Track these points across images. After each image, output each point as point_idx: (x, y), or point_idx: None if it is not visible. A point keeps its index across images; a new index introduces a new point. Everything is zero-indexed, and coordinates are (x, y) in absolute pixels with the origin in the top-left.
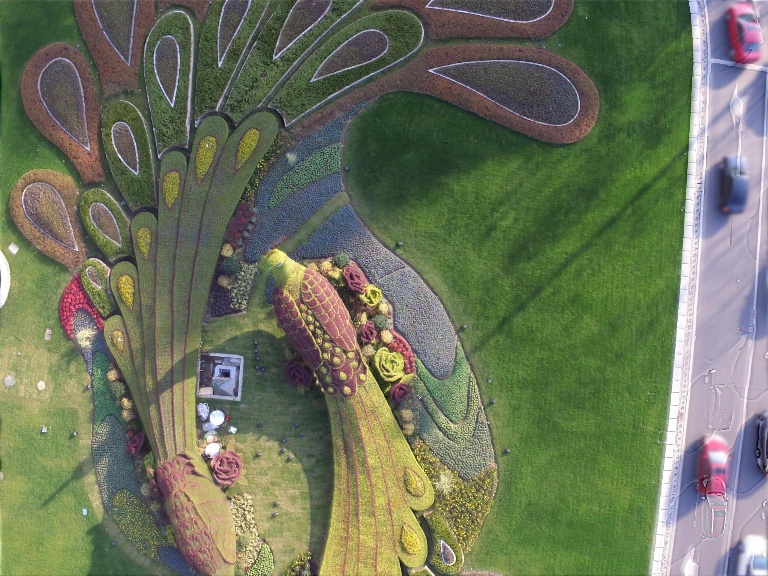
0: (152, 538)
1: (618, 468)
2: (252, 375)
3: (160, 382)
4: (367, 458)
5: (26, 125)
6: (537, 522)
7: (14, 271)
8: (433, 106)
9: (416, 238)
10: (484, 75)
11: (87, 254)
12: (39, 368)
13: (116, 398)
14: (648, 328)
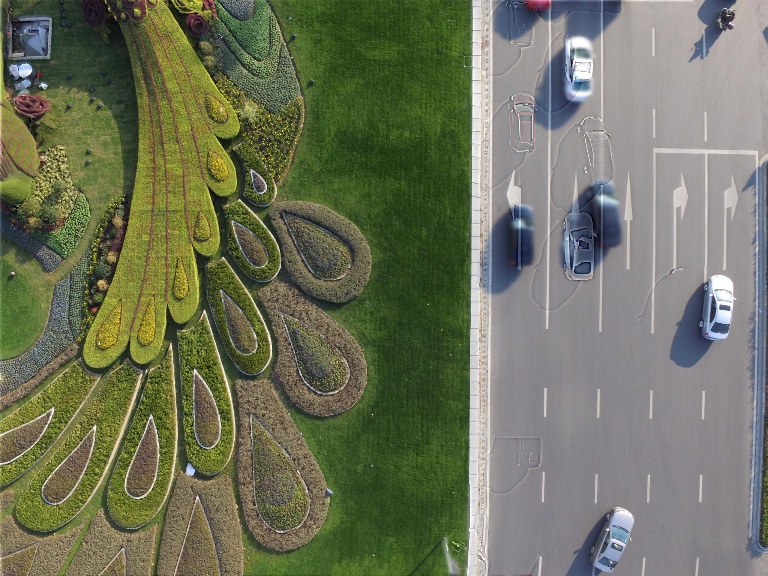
0: None
1: (425, 92)
2: (60, 33)
3: None
4: (165, 83)
5: None
6: (348, 149)
7: None
8: None
9: None
10: None
11: None
12: None
13: None
14: None
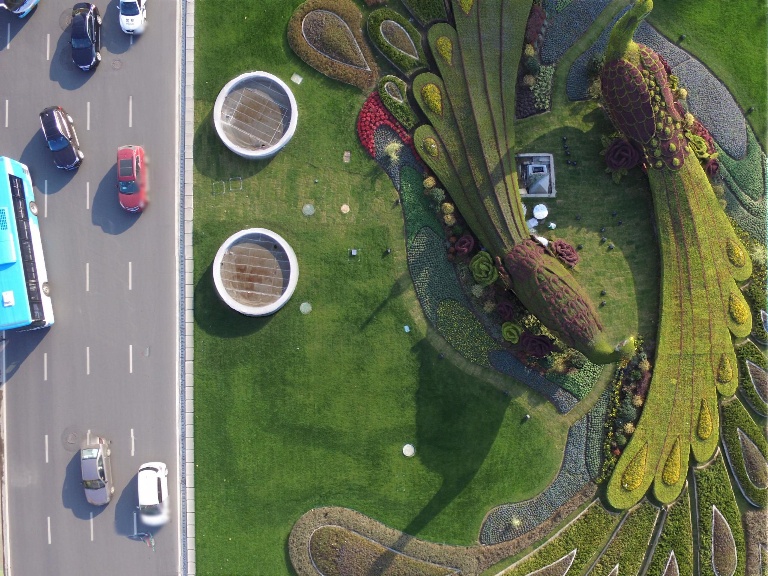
0: (483, 343)
1: None
2: (564, 170)
3: (492, 174)
4: (696, 230)
5: None
6: None
7: (300, 100)
8: None
9: (696, 31)
10: None
11: (379, 73)
12: (341, 192)
13: (436, 204)
14: None
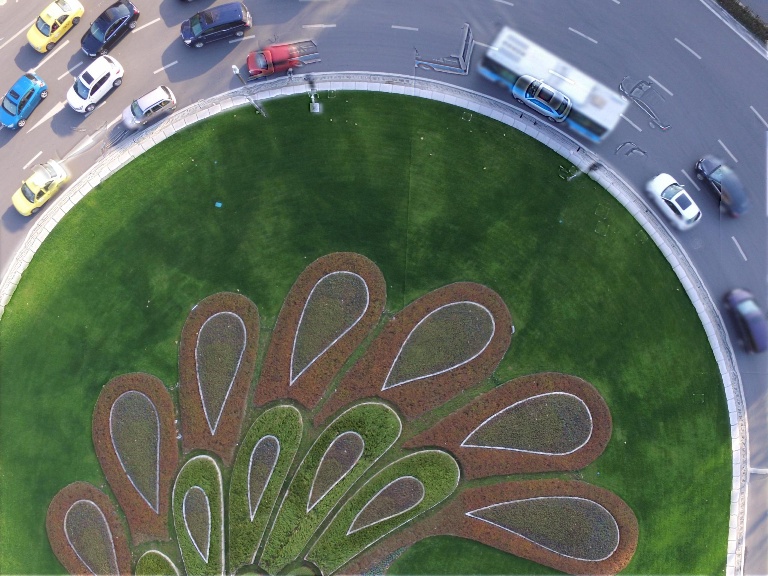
0: None
1: None
2: None
3: None
4: None
5: (56, 565)
6: None
7: None
8: (472, 548)
9: None
10: (523, 518)
11: None
12: None
13: None
14: None
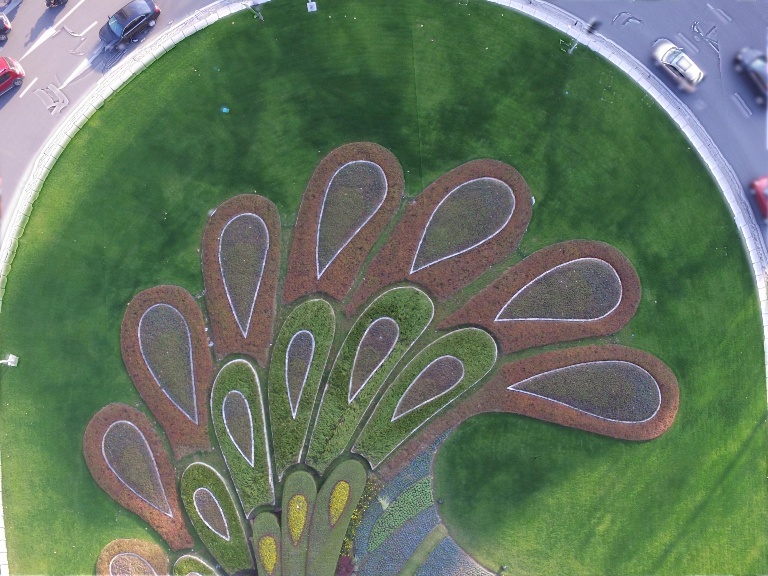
0: None
1: None
2: None
3: None
4: None
5: (97, 493)
6: None
7: None
8: (517, 423)
9: (519, 558)
10: (564, 385)
11: None
12: None
13: None
14: None
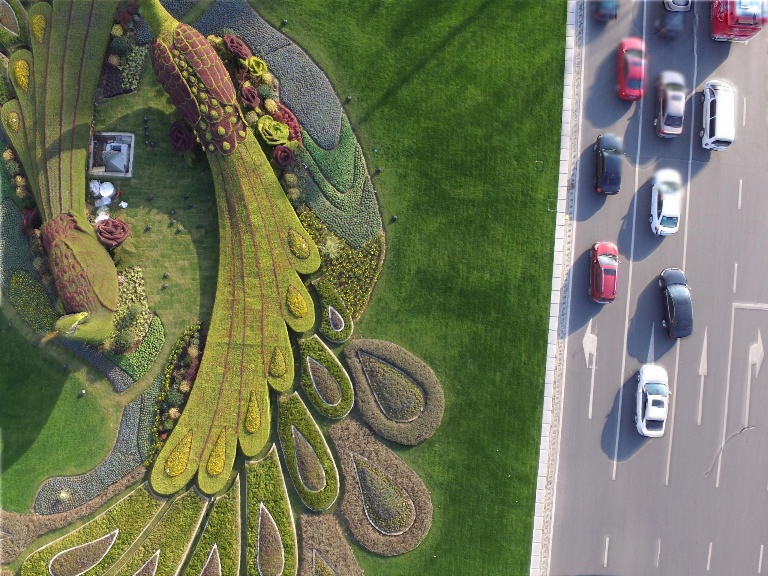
0: (46, 315)
1: (508, 235)
2: (142, 151)
3: (48, 149)
4: (249, 216)
5: None
6: (427, 289)
7: None
8: None
9: (301, 16)
10: None
11: None
12: None
13: (11, 176)
14: (534, 98)
